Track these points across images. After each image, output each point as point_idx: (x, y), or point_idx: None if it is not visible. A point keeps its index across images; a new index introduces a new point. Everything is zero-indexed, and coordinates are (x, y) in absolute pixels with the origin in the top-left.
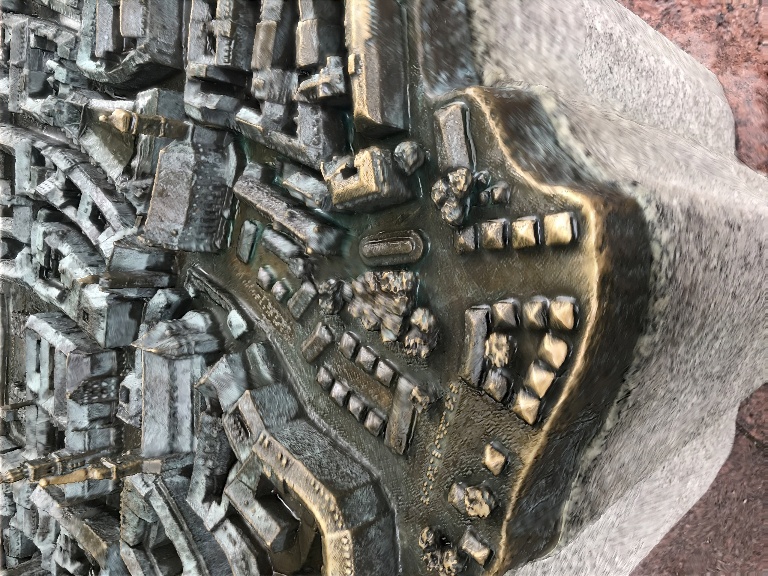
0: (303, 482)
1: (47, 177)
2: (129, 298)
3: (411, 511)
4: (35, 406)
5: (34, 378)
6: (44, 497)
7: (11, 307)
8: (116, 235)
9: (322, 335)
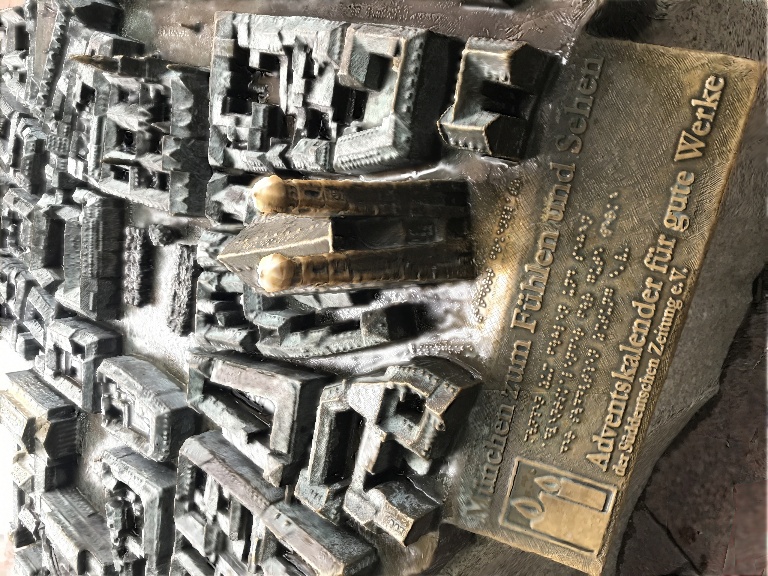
0: None
1: (53, 153)
2: (96, 3)
3: None
4: (147, 189)
5: None
6: None
7: (137, 342)
8: None
9: None
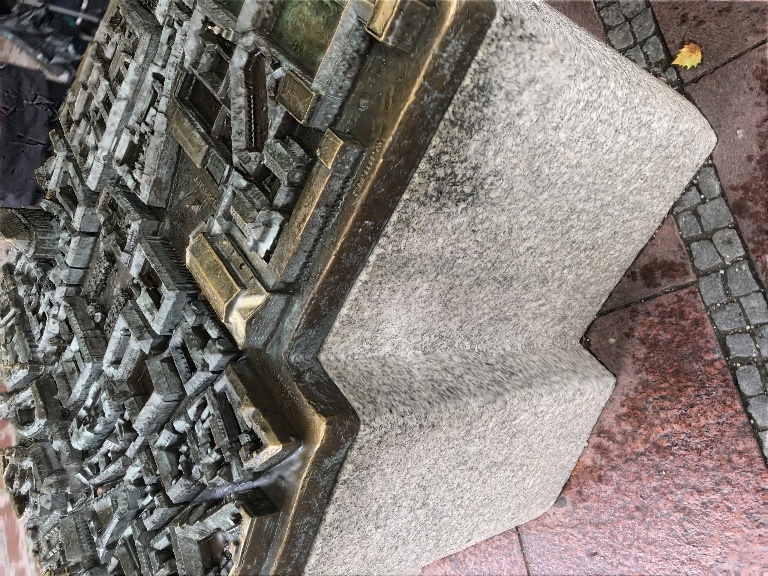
0: (23, 521)
1: None
2: None
3: (39, 527)
4: None
5: (77, 343)
6: (60, 298)
7: None
8: (86, 480)
9: (60, 541)
